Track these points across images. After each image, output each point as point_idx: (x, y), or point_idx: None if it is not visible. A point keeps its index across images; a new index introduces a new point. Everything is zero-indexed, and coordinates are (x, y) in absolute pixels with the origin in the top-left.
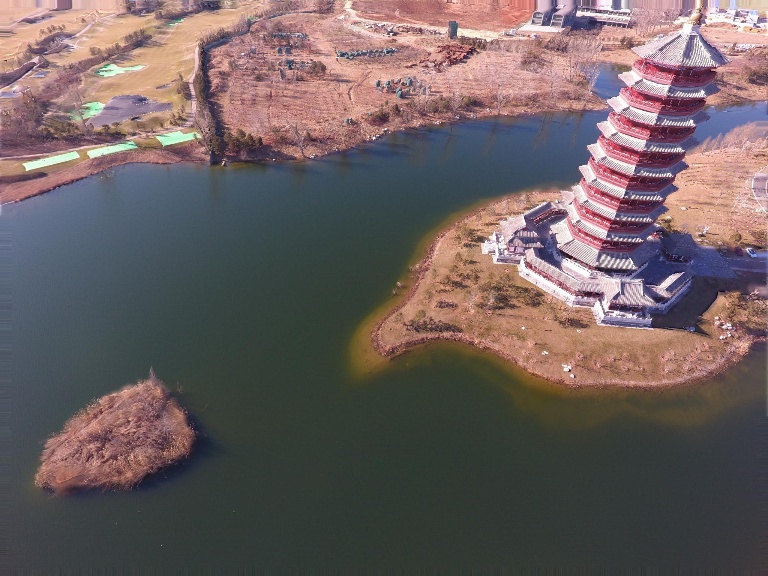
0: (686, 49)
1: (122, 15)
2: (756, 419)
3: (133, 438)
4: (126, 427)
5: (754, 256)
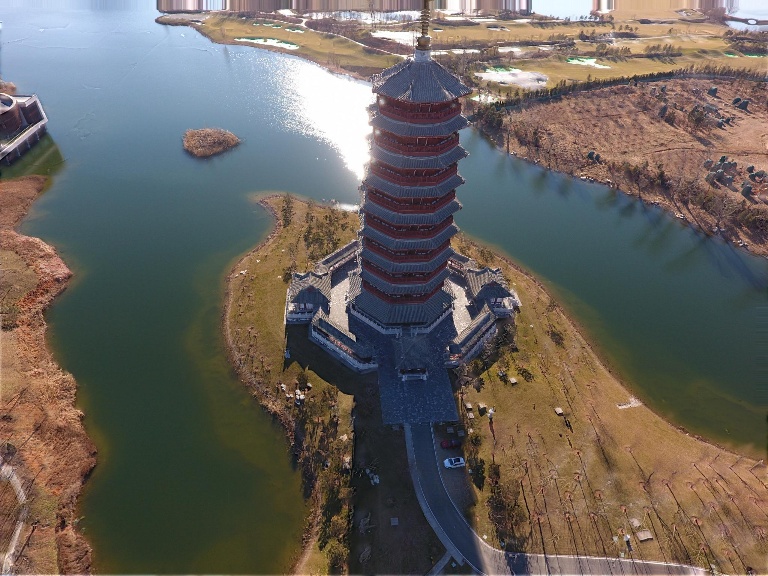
0: (395, 69)
1: (713, 37)
2: (188, 396)
3: None
4: (211, 138)
5: (445, 462)
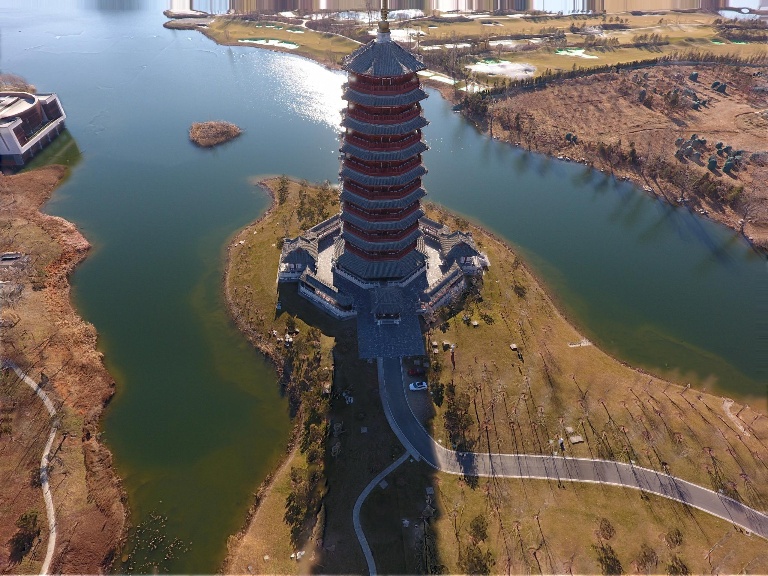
0: (361, 50)
1: (702, 26)
2: (193, 342)
3: (208, 131)
4: None
5: (410, 386)
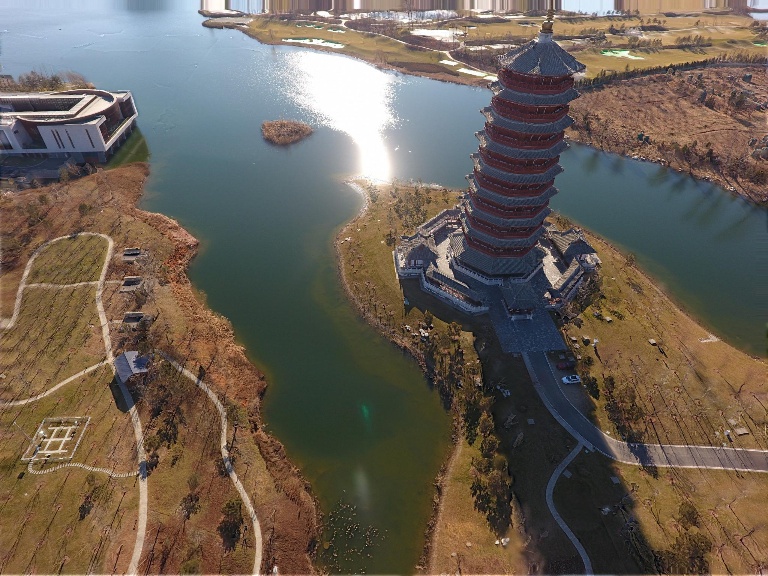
0: (518, 50)
1: (739, 28)
2: (325, 336)
3: (281, 130)
4: None
5: (564, 379)
